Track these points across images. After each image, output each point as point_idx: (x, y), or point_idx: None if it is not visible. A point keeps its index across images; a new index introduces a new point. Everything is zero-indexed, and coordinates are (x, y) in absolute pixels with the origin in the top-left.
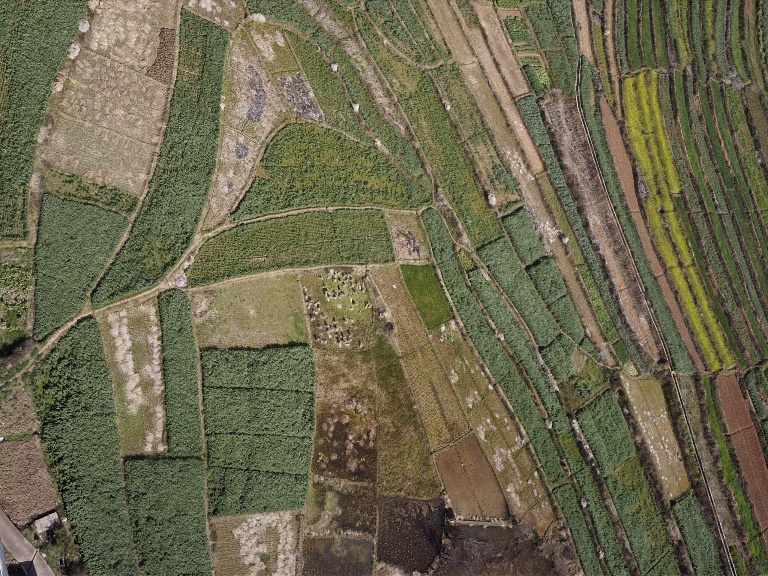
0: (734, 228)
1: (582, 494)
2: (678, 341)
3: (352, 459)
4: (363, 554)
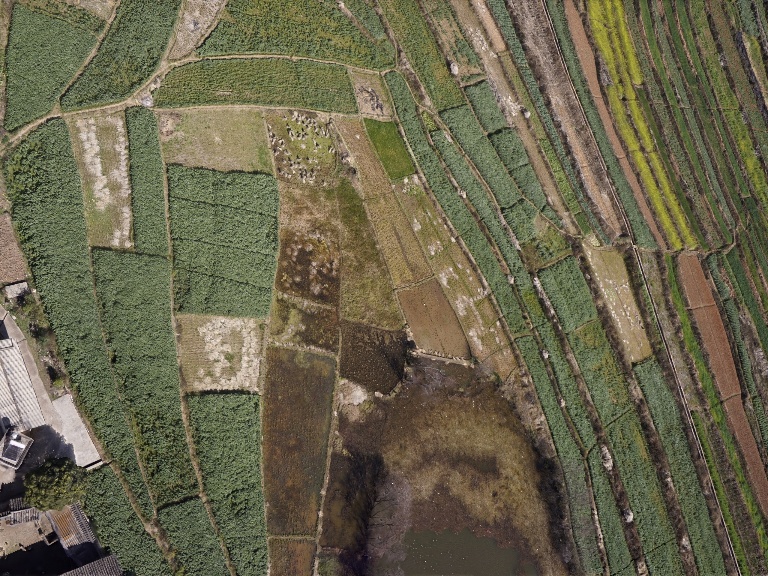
0: (696, 122)
1: (544, 346)
2: (640, 219)
3: (315, 283)
4: (326, 369)
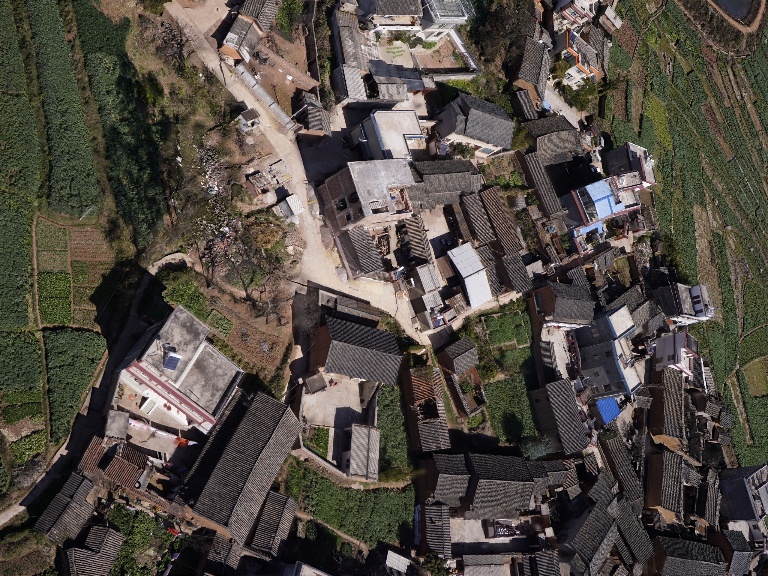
0: None
1: None
2: None
3: None
4: None
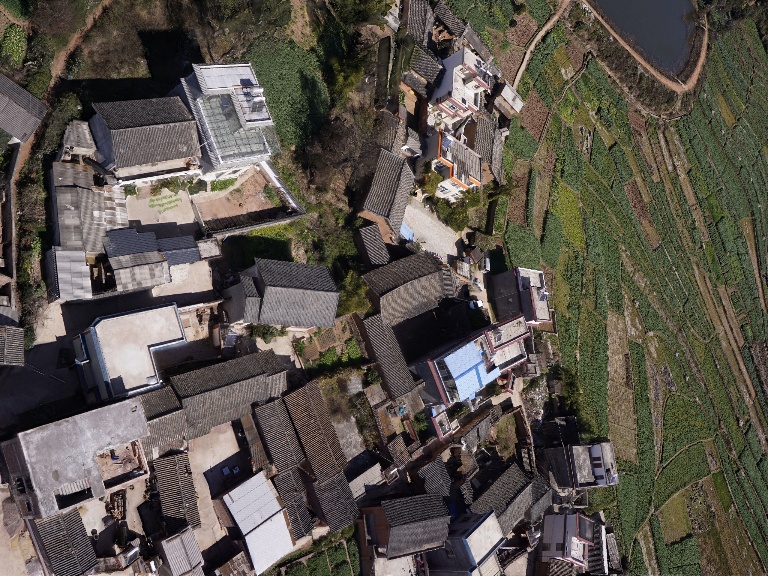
0: None
1: None
2: None
3: None
4: None
